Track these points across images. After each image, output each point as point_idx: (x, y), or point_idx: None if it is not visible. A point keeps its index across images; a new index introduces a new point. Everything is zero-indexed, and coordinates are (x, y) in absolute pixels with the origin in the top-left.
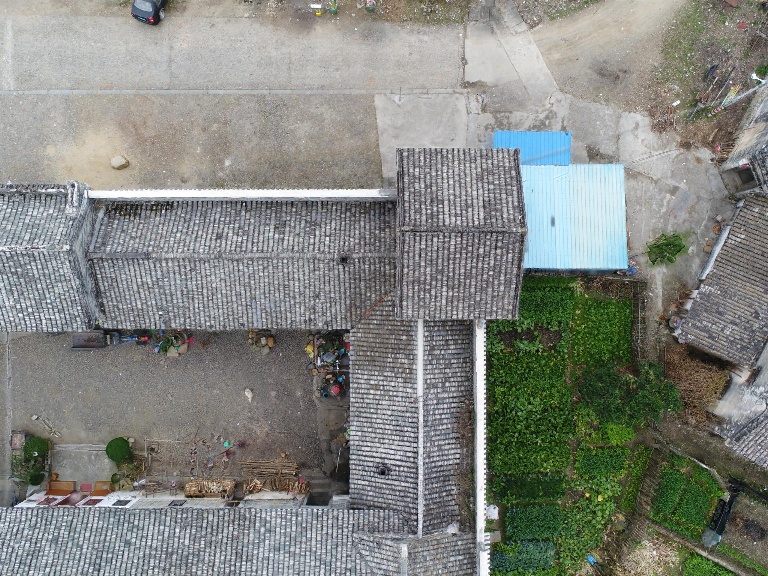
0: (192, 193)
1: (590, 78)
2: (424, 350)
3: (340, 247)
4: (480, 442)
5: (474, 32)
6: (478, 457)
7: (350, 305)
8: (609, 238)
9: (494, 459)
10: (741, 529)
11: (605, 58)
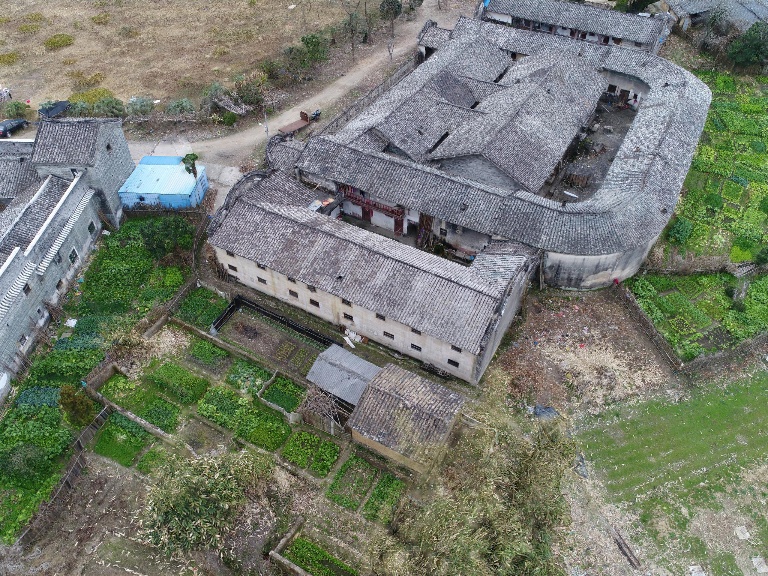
0: None
1: (214, 157)
2: (44, 190)
3: None
4: (50, 216)
5: (162, 144)
6: (45, 222)
7: (19, 185)
8: (185, 185)
9: (86, 292)
10: (242, 332)
11: (224, 151)
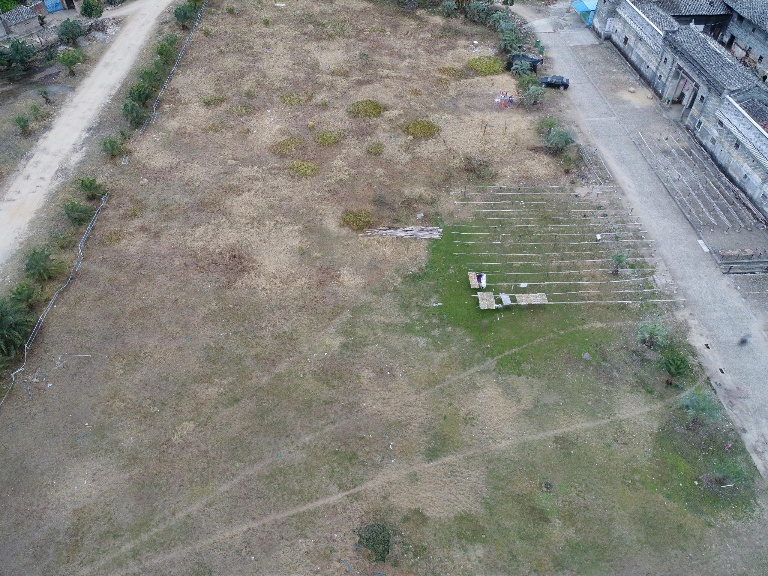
0: None
1: None
2: None
3: None
4: None
5: None
6: None
7: None
8: None
9: None
10: None
11: None
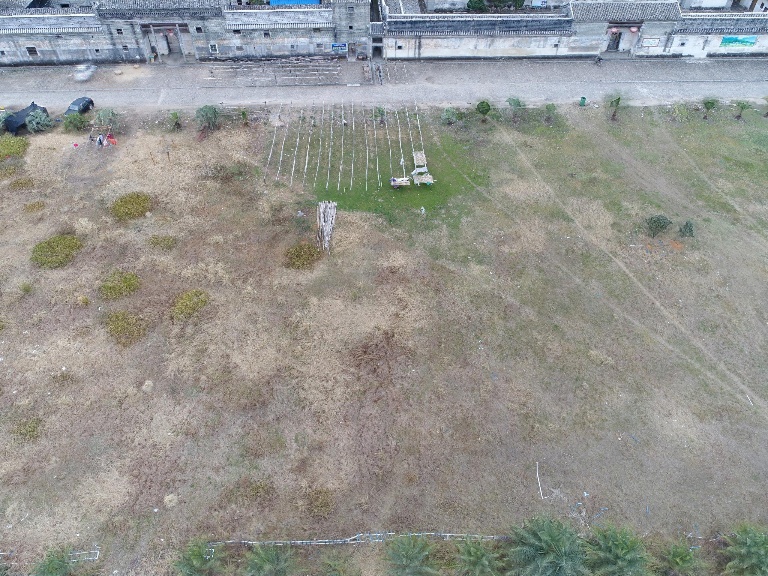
0: (56, 15)
1: None
2: None
3: (8, 12)
4: None
5: None
6: None
7: None
8: None
9: None
10: None
11: None
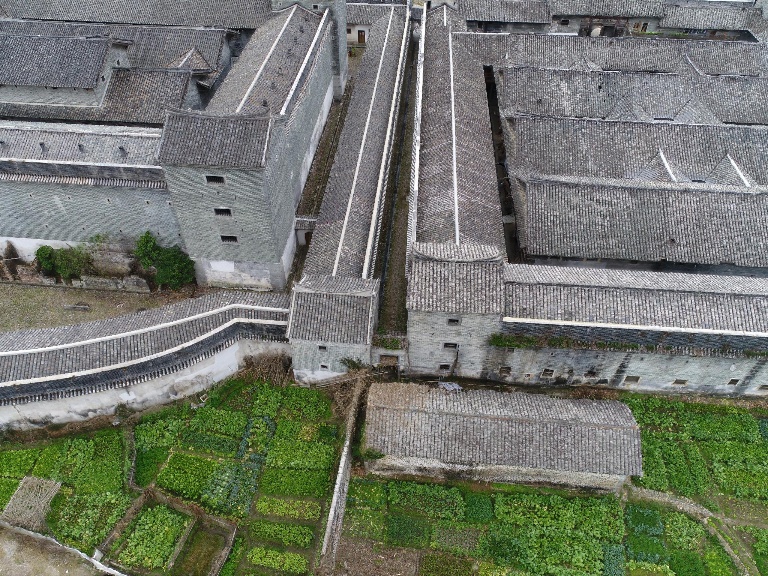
0: None
1: None
2: None
3: None
4: None
5: None
6: None
7: (747, 23)
8: None
9: None
10: None
11: None
